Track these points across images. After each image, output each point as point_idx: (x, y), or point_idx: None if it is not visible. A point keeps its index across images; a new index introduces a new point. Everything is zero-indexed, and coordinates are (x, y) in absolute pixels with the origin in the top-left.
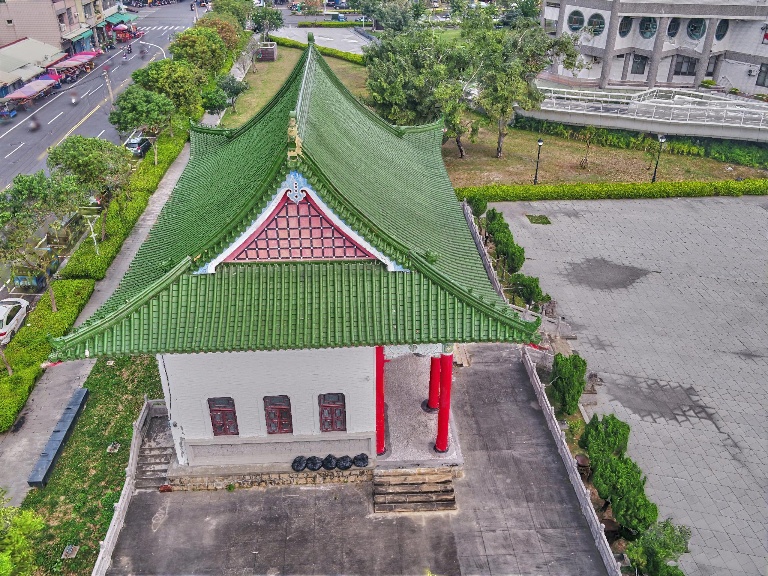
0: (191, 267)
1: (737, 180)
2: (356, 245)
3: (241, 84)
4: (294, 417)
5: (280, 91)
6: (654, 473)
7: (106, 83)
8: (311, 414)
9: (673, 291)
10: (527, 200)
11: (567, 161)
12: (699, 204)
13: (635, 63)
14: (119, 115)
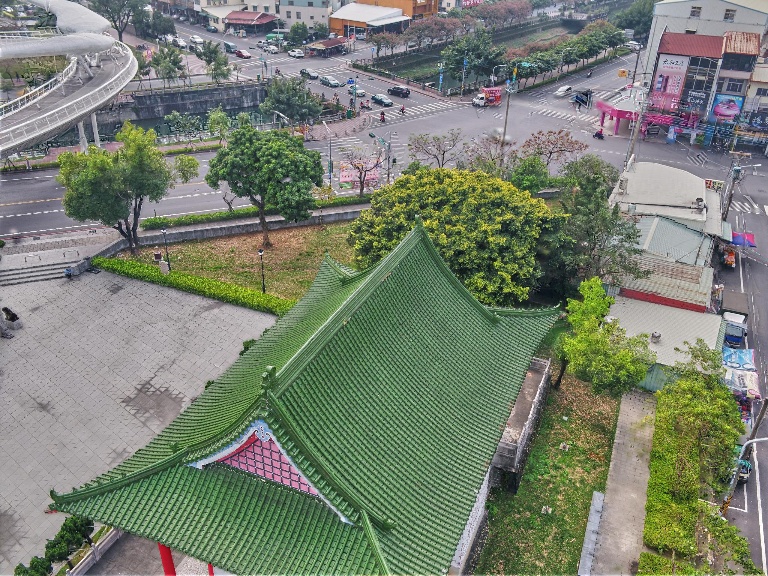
0: None
1: None
2: None
3: None
4: None
5: None
6: None
7: None
8: None
9: None
10: None
11: None
12: None
13: None
14: None
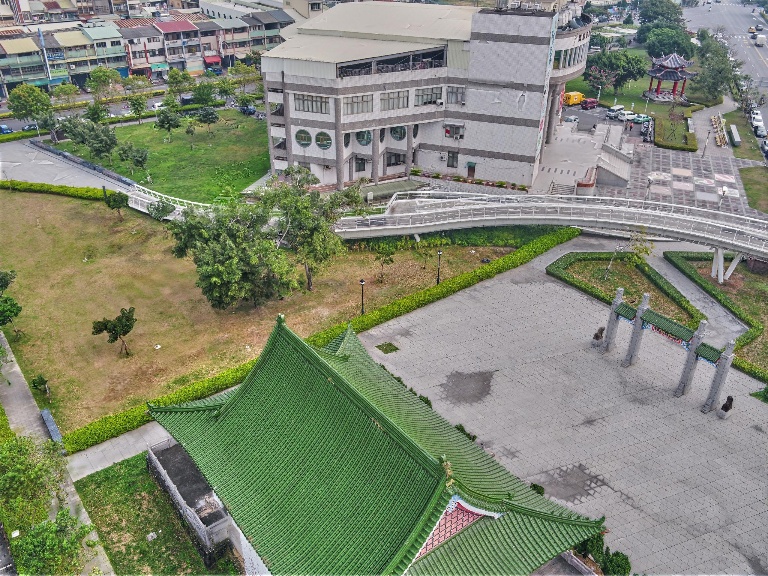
0: None
1: (483, 261)
2: (475, 513)
3: (7, 274)
4: None
5: (257, 365)
6: (607, 542)
7: None
8: None
9: (517, 385)
10: (365, 330)
11: (364, 277)
12: (476, 293)
13: (357, 163)
14: None
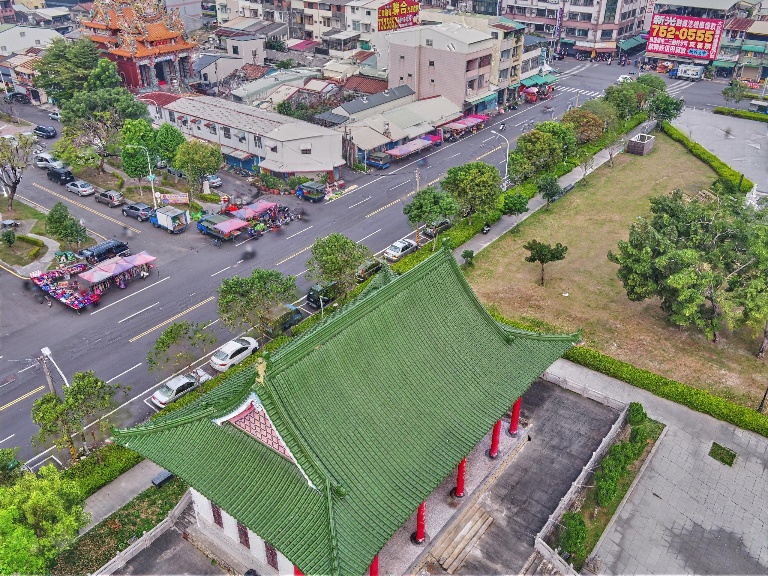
0: (209, 415)
1: None
2: None
3: (559, 188)
4: (250, 542)
5: None
6: None
7: (416, 178)
8: (259, 547)
9: None
10: (735, 425)
11: None
12: None
13: None
14: (411, 208)
